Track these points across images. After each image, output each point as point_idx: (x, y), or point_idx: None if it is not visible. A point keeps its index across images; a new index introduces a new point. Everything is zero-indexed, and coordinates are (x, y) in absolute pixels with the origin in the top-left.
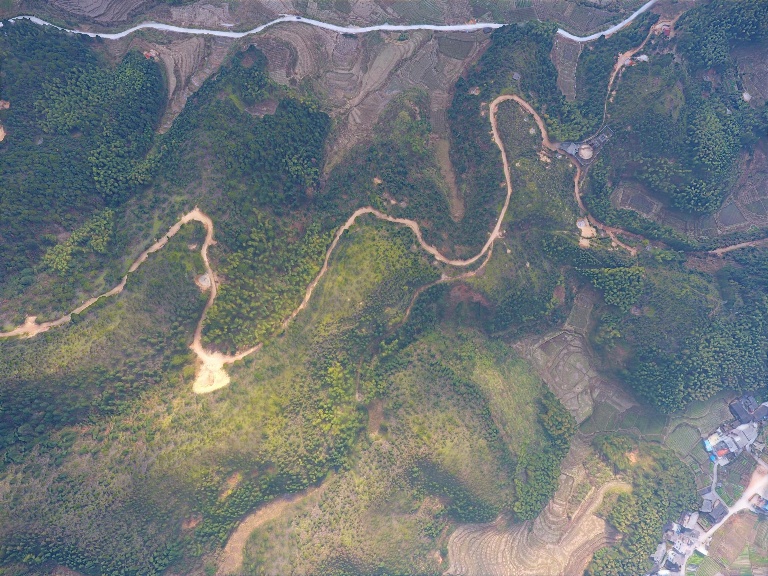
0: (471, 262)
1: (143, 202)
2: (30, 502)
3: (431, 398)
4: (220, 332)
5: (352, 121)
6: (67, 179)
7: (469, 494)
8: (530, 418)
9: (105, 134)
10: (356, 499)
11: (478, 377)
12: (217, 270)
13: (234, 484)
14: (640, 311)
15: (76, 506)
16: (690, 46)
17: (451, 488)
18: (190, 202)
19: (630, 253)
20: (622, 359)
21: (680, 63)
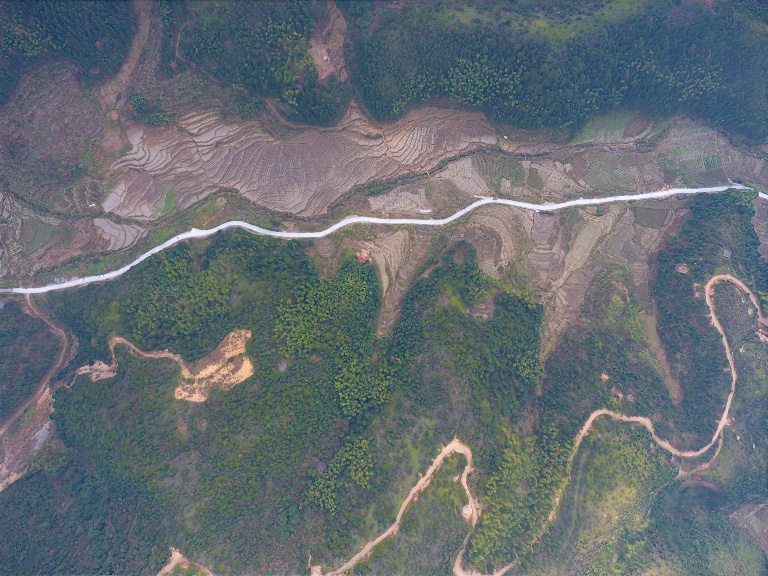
0: (703, 452)
1: (388, 423)
2: None
3: None
4: (483, 557)
5: (559, 304)
6: (321, 412)
7: None
8: None
9: (343, 354)
10: None
11: (714, 565)
12: (477, 496)
13: None
14: None
15: None
16: None
17: None
18: (448, 432)
19: None
20: None
21: None
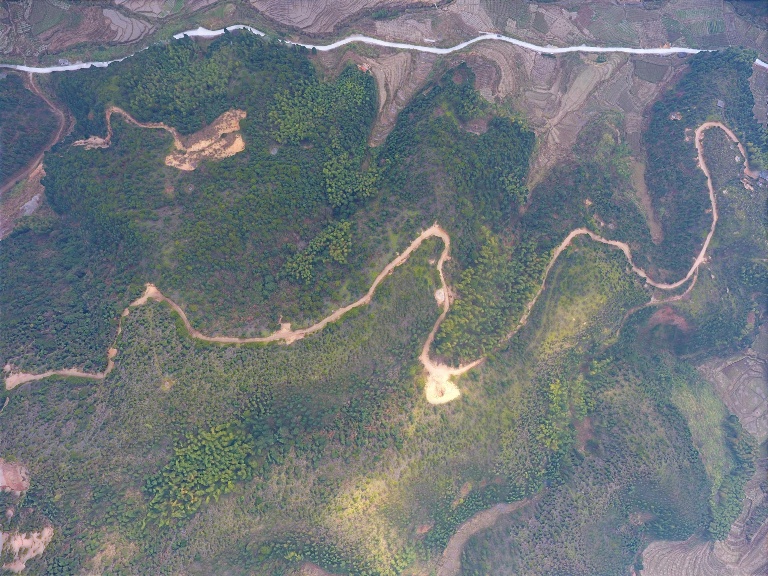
0: (676, 286)
1: (371, 214)
2: (297, 502)
3: (641, 418)
4: (450, 345)
5: (552, 140)
6: (307, 190)
7: (677, 514)
8: (719, 441)
9: (334, 146)
10: (576, 513)
11: (676, 399)
12: (451, 285)
13: (465, 493)
14: None
15: (338, 508)
16: None
17: (659, 507)
18: (429, 218)
19: None
20: None
21: None
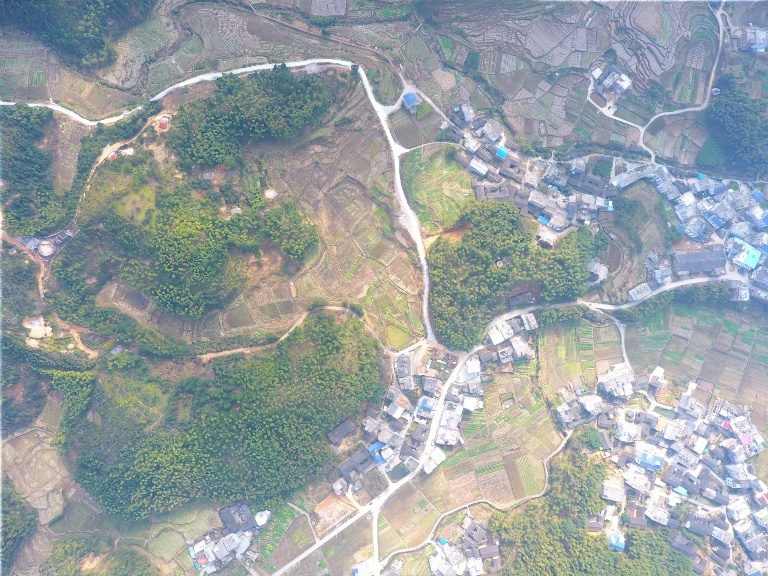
0: None
1: None
2: None
3: None
4: None
5: None
6: None
7: None
8: None
9: None
10: None
11: None
12: None
13: None
14: None
15: None
16: (175, 143)
17: None
18: None
19: (87, 356)
20: None
21: (163, 160)
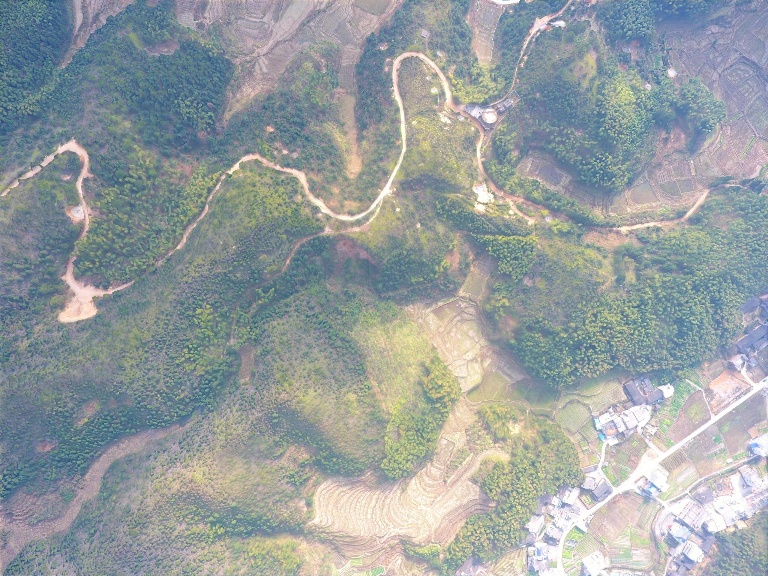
0: (358, 218)
1: (30, 132)
2: None
3: (302, 348)
4: (91, 265)
5: (258, 70)
6: None
7: (330, 445)
8: (410, 379)
9: None
10: (213, 439)
11: (357, 333)
12: None
13: (91, 413)
14: (532, 282)
15: None
16: (609, 14)
17: (314, 438)
18: (68, 133)
19: (527, 222)
20: (511, 329)
21: (597, 31)
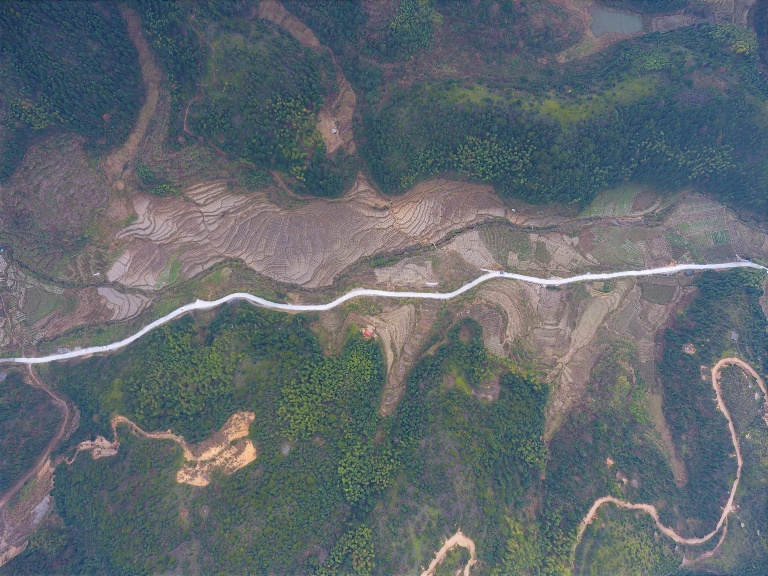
0: (707, 539)
1: (391, 508)
2: None
3: None
4: None
5: (565, 381)
6: (324, 499)
7: None
8: None
9: (347, 437)
10: None
11: None
12: None
13: None
14: None
15: None
16: None
17: None
18: (451, 524)
19: None
20: None
21: None
